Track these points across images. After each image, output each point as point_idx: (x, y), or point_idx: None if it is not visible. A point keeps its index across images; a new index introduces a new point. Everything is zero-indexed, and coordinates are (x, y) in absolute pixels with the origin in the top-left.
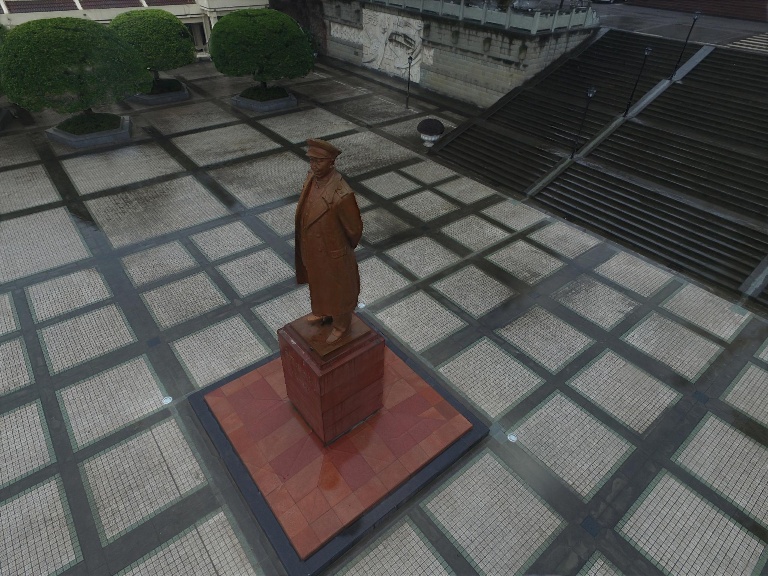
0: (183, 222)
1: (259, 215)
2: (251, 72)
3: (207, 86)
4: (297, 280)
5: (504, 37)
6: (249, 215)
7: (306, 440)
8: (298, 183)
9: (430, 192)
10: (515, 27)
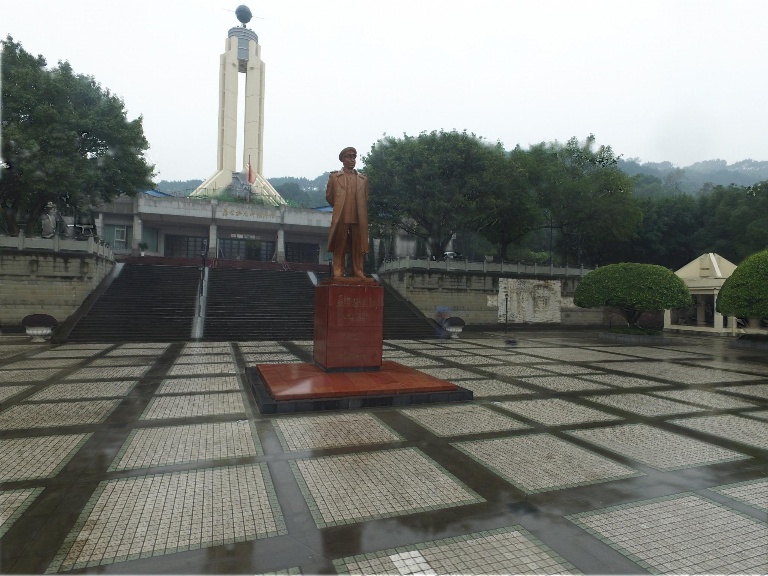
0: None
1: None
2: None
3: None
4: None
5: (56, 258)
6: None
7: None
8: None
9: (121, 349)
10: (67, 249)
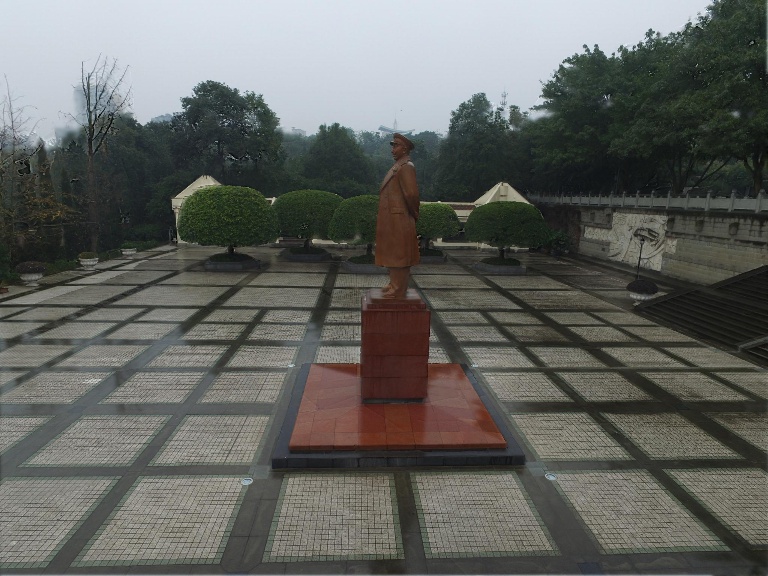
0: None
1: (439, 312)
2: (489, 239)
3: (462, 259)
4: None
5: (753, 220)
6: None
7: (352, 397)
8: (486, 304)
9: (612, 328)
10: (767, 210)
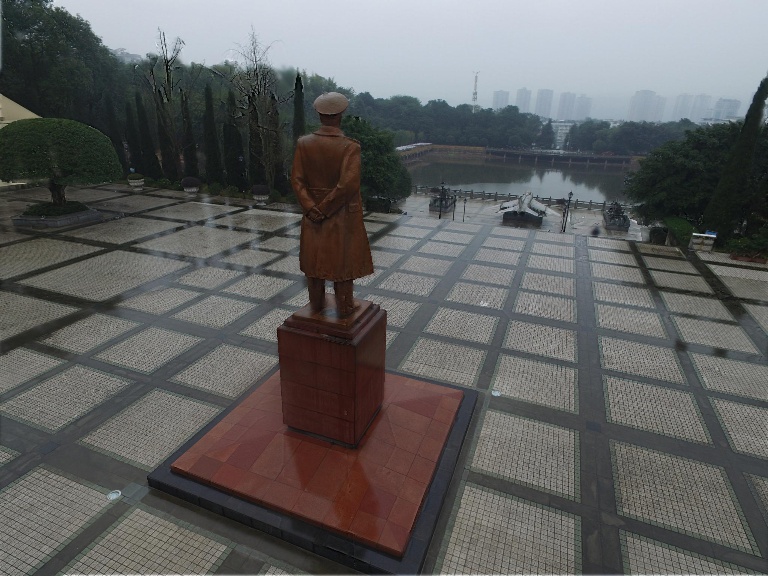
0: None
1: None
2: None
3: None
4: None
5: None
6: None
7: None
8: None
9: None
10: None
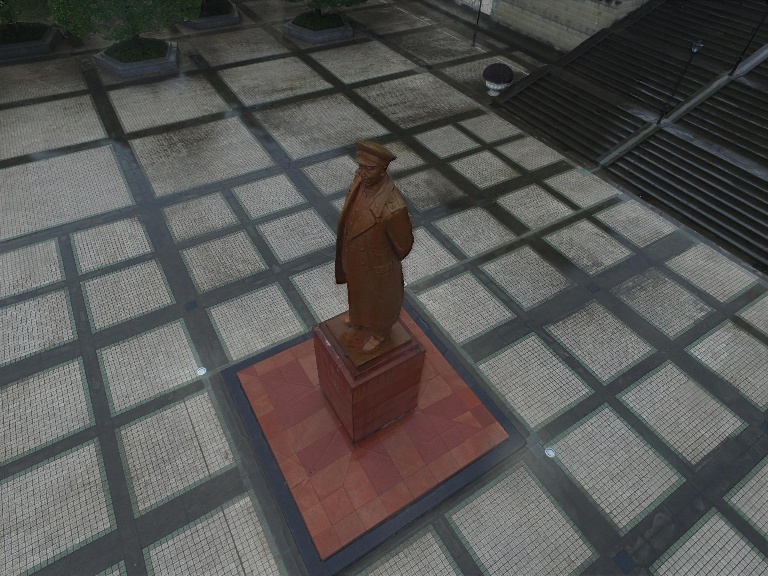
0: (226, 171)
1: (304, 168)
2: None
3: (259, 8)
4: None
5: None
6: (294, 168)
7: (335, 434)
8: (347, 133)
9: (489, 153)
10: None
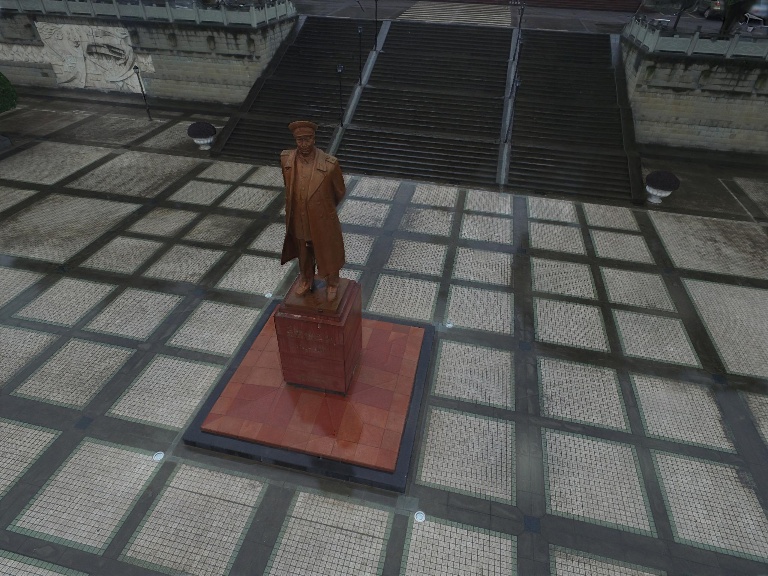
0: None
1: (83, 264)
2: None
3: None
4: (282, 261)
5: (227, 33)
6: (70, 269)
7: (326, 401)
8: (98, 221)
9: (244, 187)
10: (234, 23)
